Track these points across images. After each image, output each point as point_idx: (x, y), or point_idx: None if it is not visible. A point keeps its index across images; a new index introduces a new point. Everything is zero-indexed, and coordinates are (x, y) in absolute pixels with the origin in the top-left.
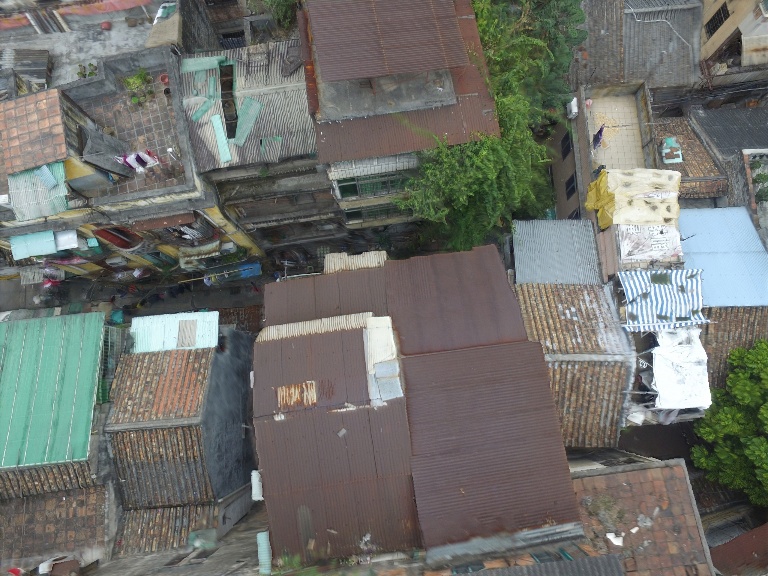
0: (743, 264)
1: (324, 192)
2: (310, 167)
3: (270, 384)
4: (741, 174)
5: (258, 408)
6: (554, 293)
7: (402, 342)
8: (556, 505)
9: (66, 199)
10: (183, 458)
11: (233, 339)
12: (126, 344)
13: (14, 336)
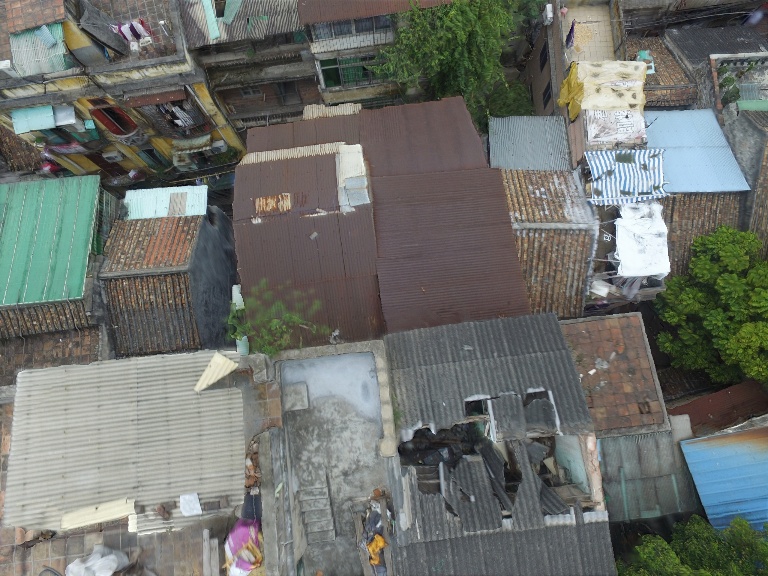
0: (707, 157)
1: (309, 81)
2: (295, 53)
3: (249, 196)
4: (708, 78)
5: (237, 214)
6: (525, 177)
7: (372, 169)
8: (509, 305)
9: (64, 57)
10: (172, 305)
11: (222, 219)
12: (120, 213)
13: (15, 196)
